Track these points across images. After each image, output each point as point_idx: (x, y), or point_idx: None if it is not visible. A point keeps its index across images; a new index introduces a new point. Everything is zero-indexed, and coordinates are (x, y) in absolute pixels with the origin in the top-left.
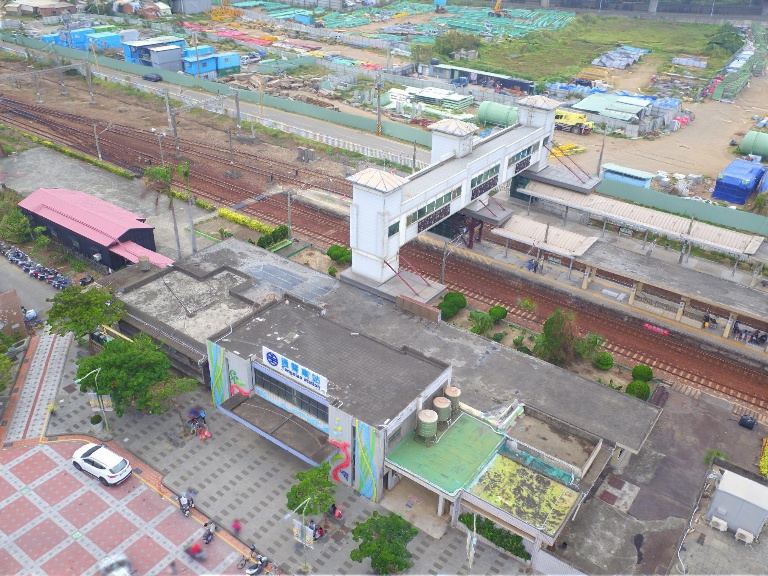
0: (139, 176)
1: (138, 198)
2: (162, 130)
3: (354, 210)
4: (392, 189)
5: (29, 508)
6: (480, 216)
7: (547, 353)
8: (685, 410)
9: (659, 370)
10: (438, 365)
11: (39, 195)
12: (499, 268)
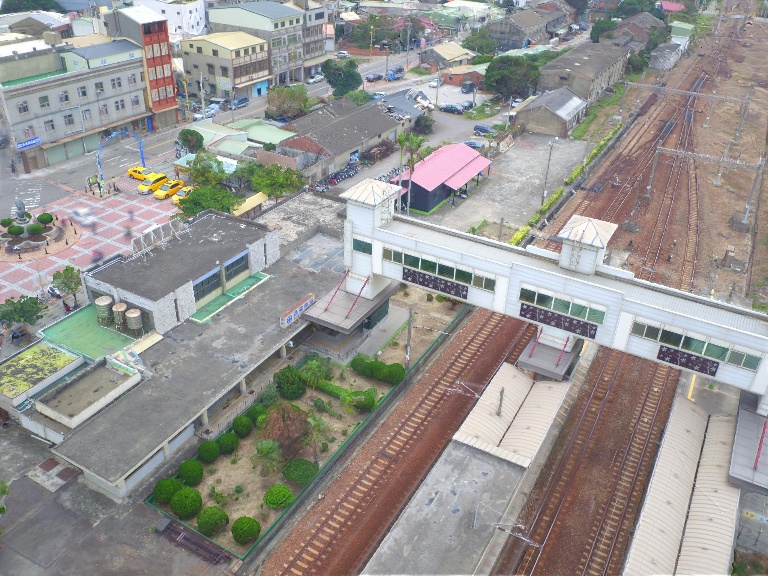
0: (584, 188)
1: (528, 193)
2: (710, 181)
3: None
4: (346, 197)
5: (134, 225)
6: None
7: None
8: (179, 575)
9: (279, 573)
10: None
11: None
12: None
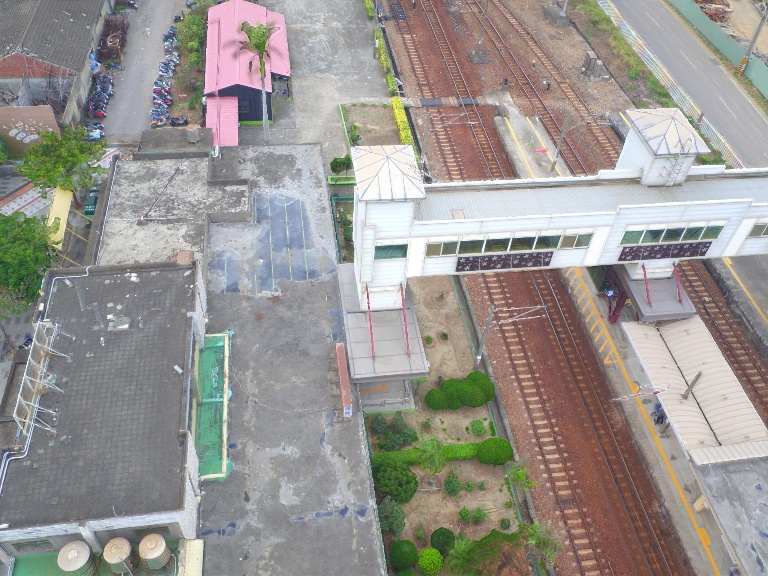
0: (388, 18)
1: (346, 45)
2: None
3: (355, 196)
4: (373, 198)
5: None
6: (629, 290)
7: (456, 573)
8: None
9: None
10: (182, 494)
11: (228, 6)
12: (612, 379)
